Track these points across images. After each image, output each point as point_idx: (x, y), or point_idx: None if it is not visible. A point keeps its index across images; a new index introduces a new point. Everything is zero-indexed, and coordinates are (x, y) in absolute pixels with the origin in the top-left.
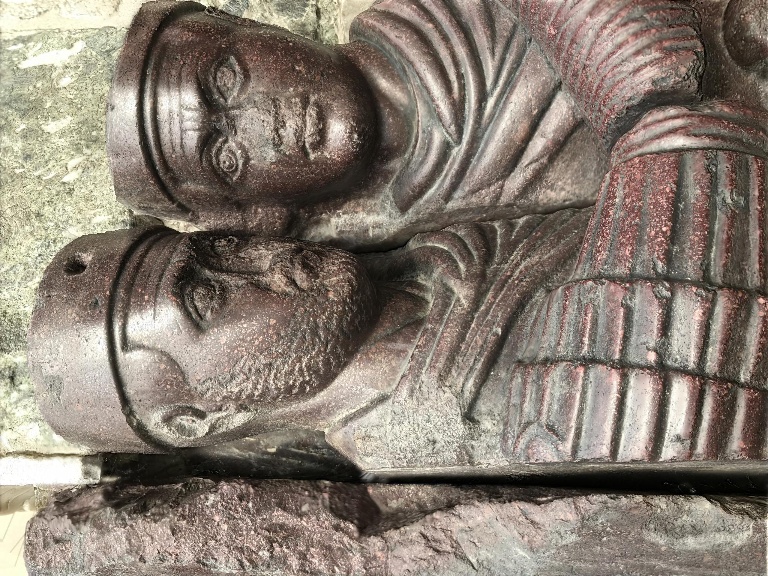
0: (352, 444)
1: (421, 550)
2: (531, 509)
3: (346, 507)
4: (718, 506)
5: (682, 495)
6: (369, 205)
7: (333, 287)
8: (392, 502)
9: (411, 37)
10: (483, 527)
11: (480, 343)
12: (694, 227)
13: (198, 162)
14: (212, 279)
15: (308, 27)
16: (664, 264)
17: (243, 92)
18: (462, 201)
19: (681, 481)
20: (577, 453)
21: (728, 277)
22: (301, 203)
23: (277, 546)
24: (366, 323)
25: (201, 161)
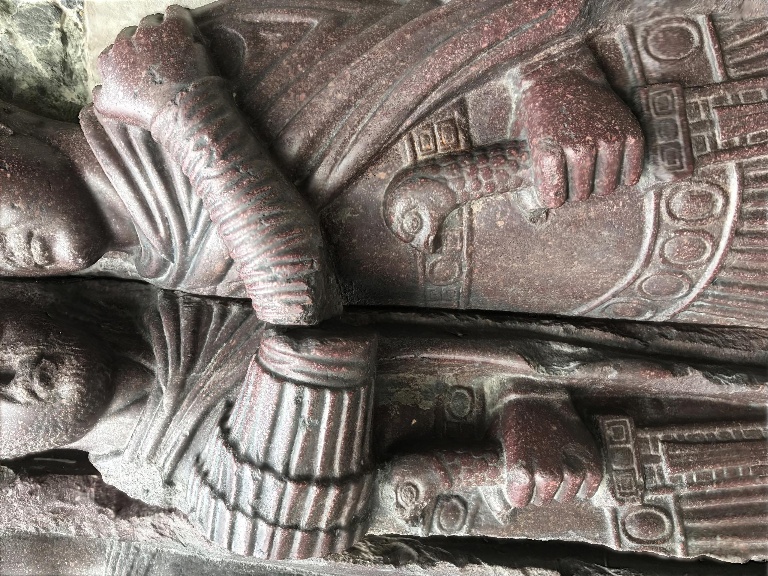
0: None
1: (152, 533)
2: None
3: (107, 496)
4: None
5: None
6: (124, 255)
7: (65, 396)
8: None
9: (119, 179)
10: None
11: (174, 440)
12: (282, 437)
13: None
14: None
15: (55, 57)
16: (262, 456)
17: None
18: (186, 290)
19: None
20: (213, 539)
21: (298, 471)
22: None
23: None
24: (100, 406)
25: None
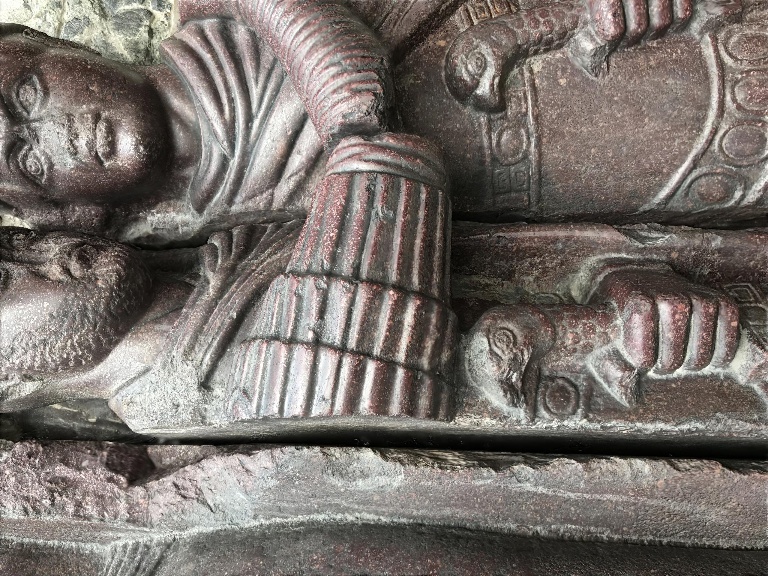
0: (122, 409)
1: (172, 497)
2: (246, 460)
3: (122, 463)
4: (378, 455)
5: (354, 447)
6: (178, 206)
7: (102, 276)
8: (166, 460)
9: (192, 65)
10: (217, 476)
11: (218, 325)
12: (352, 234)
13: (6, 166)
14: (1, 267)
15: (140, 46)
16: (328, 262)
17: (43, 107)
18: (242, 206)
19: (371, 438)
20: (260, 411)
21: (371, 273)
22: (113, 203)
23: (58, 495)
24: (136, 307)
25: (8, 165)
